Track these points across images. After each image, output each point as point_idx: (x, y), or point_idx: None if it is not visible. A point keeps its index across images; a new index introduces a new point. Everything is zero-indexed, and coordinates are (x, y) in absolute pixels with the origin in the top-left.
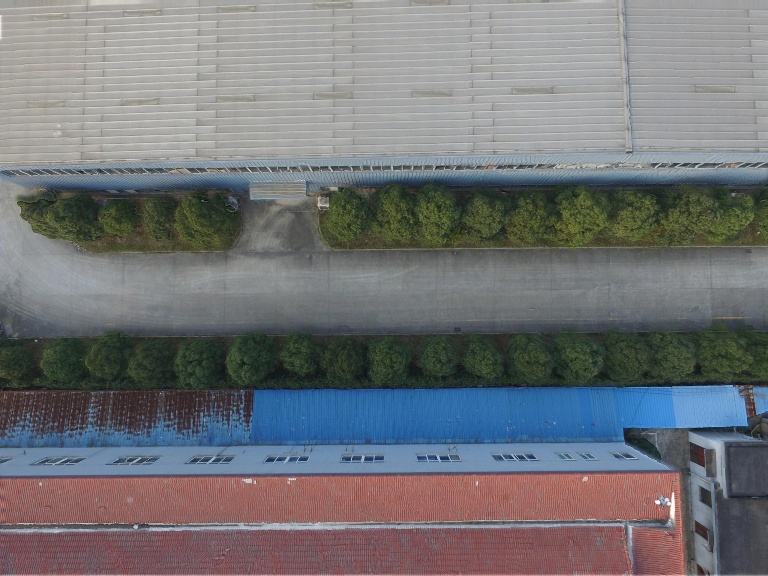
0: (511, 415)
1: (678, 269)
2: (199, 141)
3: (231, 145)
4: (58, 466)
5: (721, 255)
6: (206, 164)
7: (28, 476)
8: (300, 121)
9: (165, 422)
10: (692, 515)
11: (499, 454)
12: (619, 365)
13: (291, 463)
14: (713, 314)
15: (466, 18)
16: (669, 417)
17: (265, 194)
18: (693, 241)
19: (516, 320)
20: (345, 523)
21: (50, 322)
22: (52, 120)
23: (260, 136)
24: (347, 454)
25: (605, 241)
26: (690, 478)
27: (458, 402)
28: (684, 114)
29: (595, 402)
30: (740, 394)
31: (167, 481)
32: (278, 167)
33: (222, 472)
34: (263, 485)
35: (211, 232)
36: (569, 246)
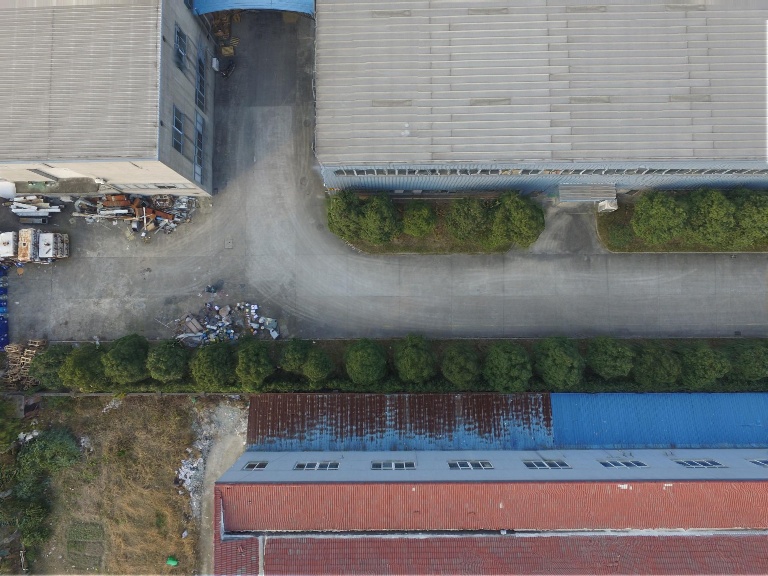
0: None
1: None
2: (554, 143)
3: (584, 147)
4: (401, 471)
5: None
6: (556, 166)
7: (395, 481)
8: (651, 123)
9: (465, 426)
10: None
11: None
12: None
13: (635, 468)
14: None
15: None
16: None
17: (574, 196)
18: None
19: None
20: (712, 529)
21: (327, 323)
22: (399, 119)
23: (616, 138)
24: (673, 459)
25: None
26: None
27: (756, 406)
28: None
29: None
30: None
31: (542, 487)
32: (617, 169)
33: (588, 477)
34: (638, 491)
35: (534, 234)
36: None
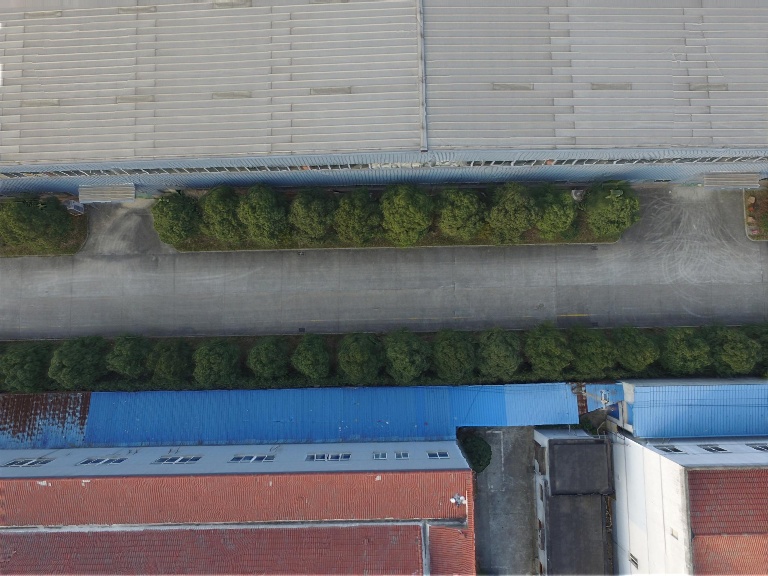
0: (345, 415)
1: (523, 267)
2: (3, 146)
3: (36, 149)
4: None
5: (567, 252)
6: (13, 168)
7: None
8: (105, 124)
9: (1, 425)
10: (537, 513)
11: (314, 454)
12: (443, 364)
13: (102, 465)
14: (558, 312)
15: (267, 20)
16: (501, 415)
17: (94, 197)
18: (524, 239)
19: (360, 320)
20: (144, 524)
21: None
22: None
23: (64, 140)
24: (168, 455)
25: (449, 240)
26: (535, 476)
27: (293, 402)
28: (487, 112)
29: (429, 401)
30: (573, 391)
31: None
32: (91, 170)
33: (22, 475)
34: (58, 487)
35: (33, 236)
36: (414, 245)
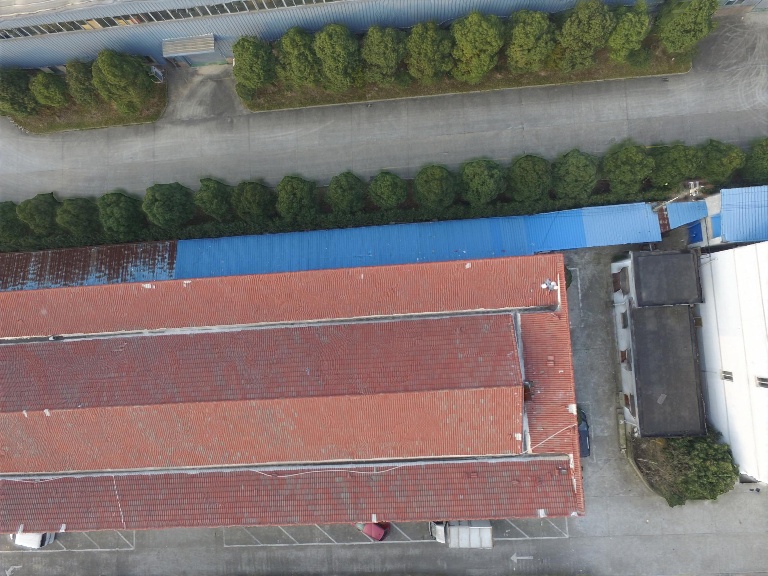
0: (421, 247)
1: (592, 103)
2: None
3: None
4: None
5: (636, 86)
6: (108, 8)
7: None
8: None
9: (97, 274)
10: (618, 347)
11: None
12: (521, 182)
13: None
14: (630, 145)
15: None
16: (579, 237)
17: (176, 50)
18: (596, 61)
19: (430, 165)
20: (241, 325)
21: None
22: None
23: None
24: None
25: (516, 81)
26: (615, 310)
27: (370, 239)
28: None
29: (505, 230)
30: (653, 210)
31: (75, 290)
32: (177, 10)
33: None
34: None
35: (124, 83)
36: (480, 89)
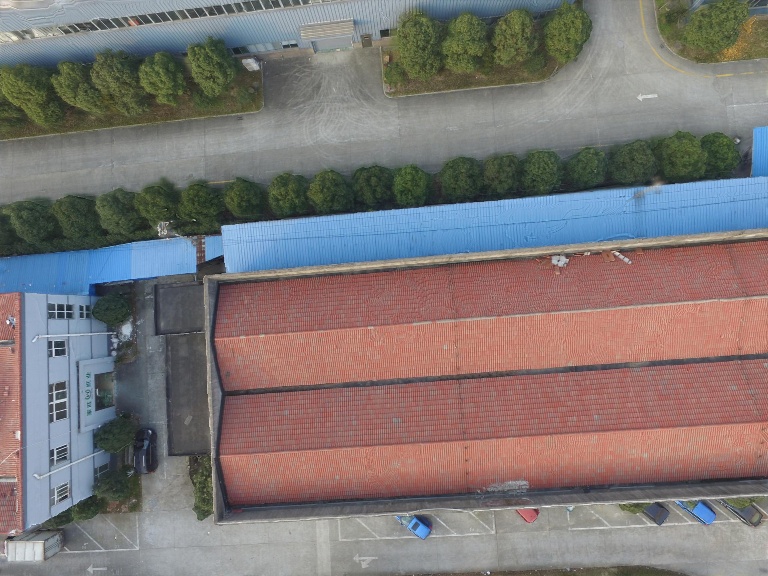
0: None
1: (175, 141)
2: None
3: None
4: None
5: (214, 125)
6: None
7: None
8: None
9: None
10: None
11: None
12: (60, 221)
13: None
14: (206, 180)
15: None
16: (127, 270)
17: None
18: (144, 105)
19: None
20: None
21: None
22: None
23: None
24: None
25: (107, 122)
26: None
27: None
28: None
29: (70, 264)
30: (193, 244)
31: None
32: None
33: None
34: None
35: None
36: (76, 130)
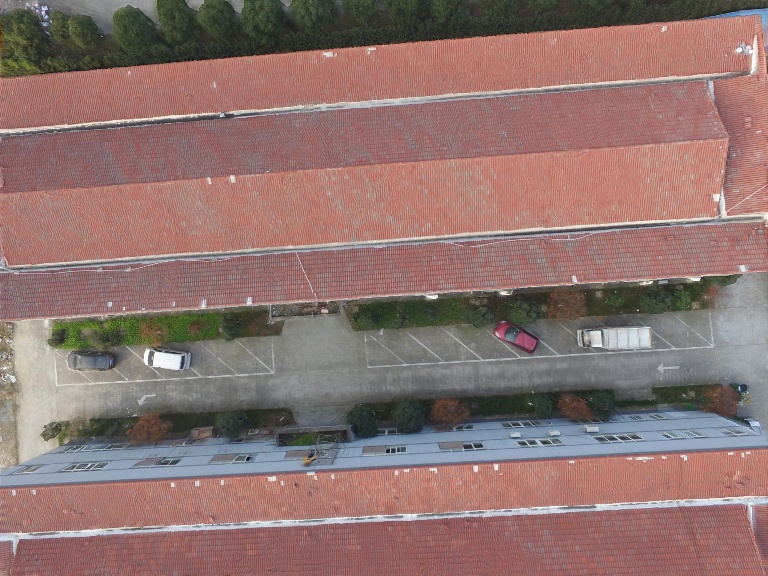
0: None
1: None
2: None
3: None
4: None
5: None
6: None
7: None
8: None
9: None
10: None
11: None
12: None
13: None
14: None
15: None
16: None
17: None
18: None
19: None
20: (425, 98)
21: None
22: None
23: None
24: None
25: None
26: None
27: None
28: None
29: None
30: None
31: None
32: None
33: None
34: None
35: None
36: None
